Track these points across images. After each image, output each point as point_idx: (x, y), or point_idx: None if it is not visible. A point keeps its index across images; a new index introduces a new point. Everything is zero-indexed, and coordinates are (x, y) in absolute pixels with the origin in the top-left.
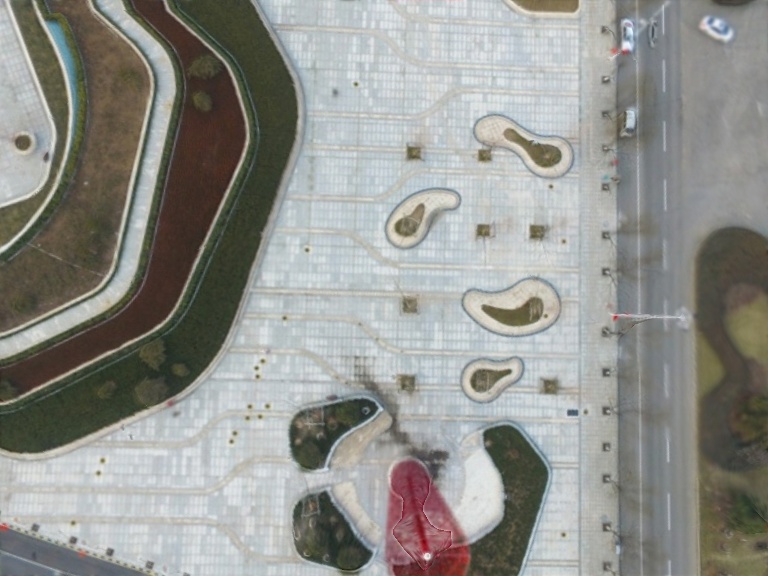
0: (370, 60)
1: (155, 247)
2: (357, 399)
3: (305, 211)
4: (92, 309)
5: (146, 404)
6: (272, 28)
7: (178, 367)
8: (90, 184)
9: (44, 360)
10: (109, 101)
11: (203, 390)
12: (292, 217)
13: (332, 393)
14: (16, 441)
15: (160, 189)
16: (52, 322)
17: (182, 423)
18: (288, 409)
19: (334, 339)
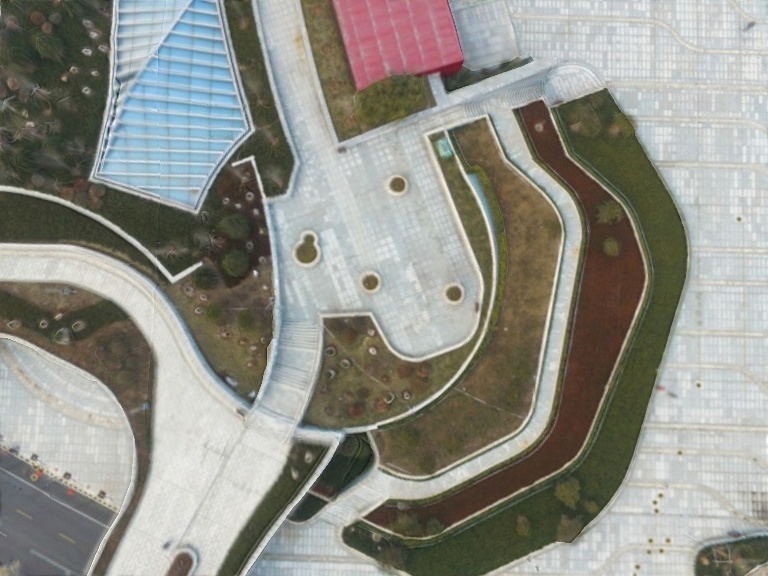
0: (752, 195)
1: (565, 388)
2: (760, 536)
3: (695, 346)
4: (511, 449)
5: (563, 541)
6: (654, 165)
7: (590, 505)
8: (509, 330)
9: (465, 497)
10: (524, 249)
11: (604, 523)
12: (682, 352)
13: (733, 529)
14: (435, 573)
15: (569, 331)
16: (475, 462)
17: (586, 556)
18: (689, 544)
19: (730, 474)
